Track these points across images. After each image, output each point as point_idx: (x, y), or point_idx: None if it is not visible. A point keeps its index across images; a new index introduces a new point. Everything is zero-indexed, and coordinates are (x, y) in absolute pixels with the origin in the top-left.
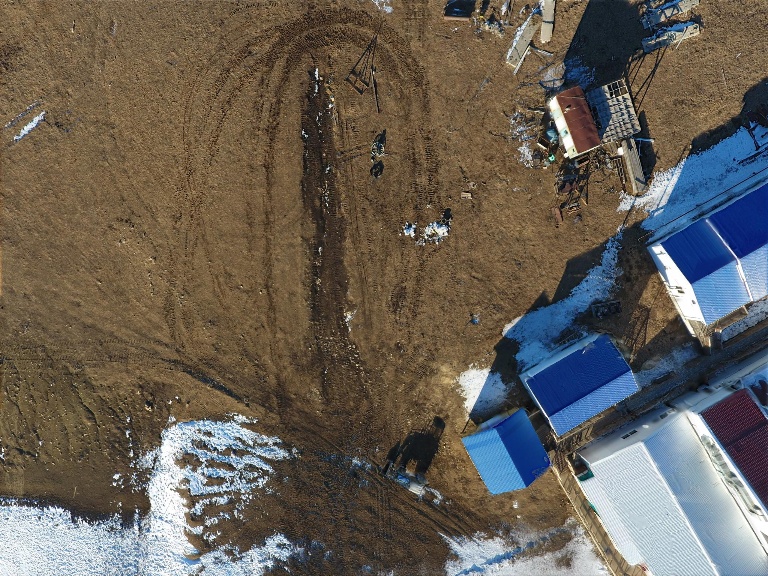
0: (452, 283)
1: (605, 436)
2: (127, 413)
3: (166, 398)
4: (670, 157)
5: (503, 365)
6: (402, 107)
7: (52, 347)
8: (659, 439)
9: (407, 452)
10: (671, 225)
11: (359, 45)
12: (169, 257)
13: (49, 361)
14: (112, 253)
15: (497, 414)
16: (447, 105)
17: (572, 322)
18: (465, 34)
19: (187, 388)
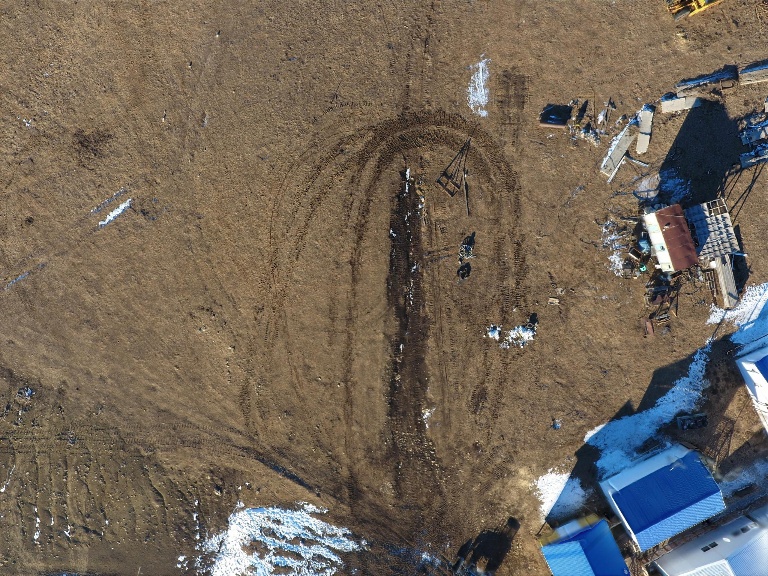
0: (535, 387)
1: (682, 544)
2: (196, 496)
3: (236, 483)
4: (763, 272)
5: (583, 471)
6: (492, 211)
7: (125, 429)
8: (743, 557)
9: (478, 550)
10: (762, 340)
11: (452, 148)
12: (248, 347)
13: (121, 443)
14: (191, 340)
15: (574, 519)
16: (538, 210)
17: (656, 432)
18: (560, 141)
19: (258, 475)
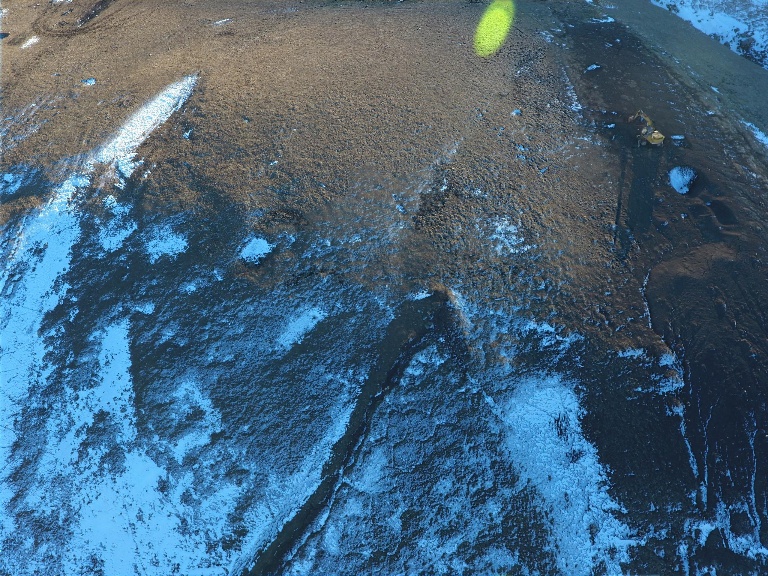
0: None
1: None
2: None
3: None
4: None
5: None
6: None
7: None
8: None
9: None
10: None
11: None
12: None
13: None
14: None
15: None
16: None
17: None
18: None
19: None
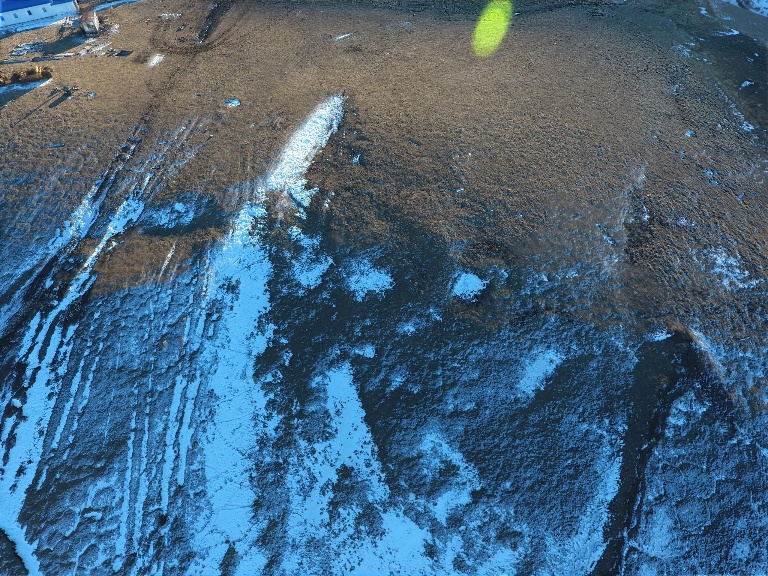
0: (167, 6)
1: None
2: None
3: None
4: (56, 25)
5: None
6: None
7: None
8: None
9: None
10: None
11: None
12: None
13: None
14: None
15: None
16: None
17: None
18: None
19: None
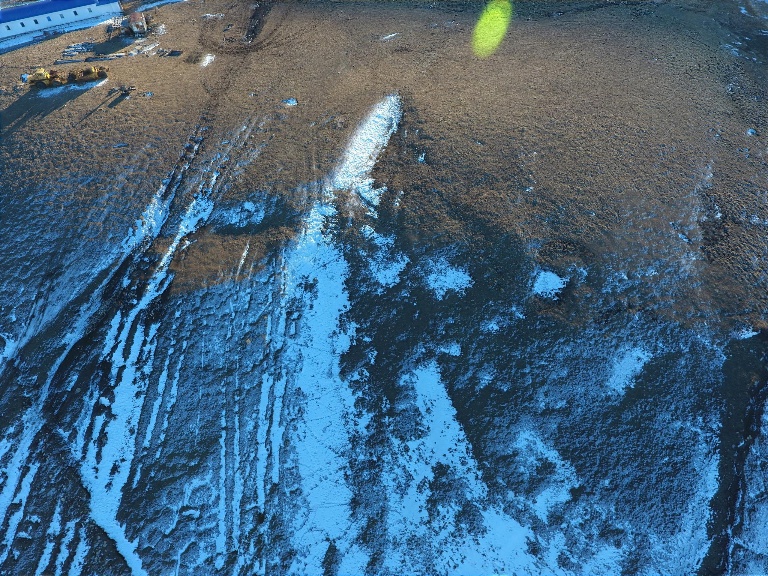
0: None
1: None
2: None
3: None
4: None
5: None
6: None
7: None
8: None
9: None
10: None
11: None
12: None
13: None
14: None
15: None
16: None
17: None
18: None
19: None
